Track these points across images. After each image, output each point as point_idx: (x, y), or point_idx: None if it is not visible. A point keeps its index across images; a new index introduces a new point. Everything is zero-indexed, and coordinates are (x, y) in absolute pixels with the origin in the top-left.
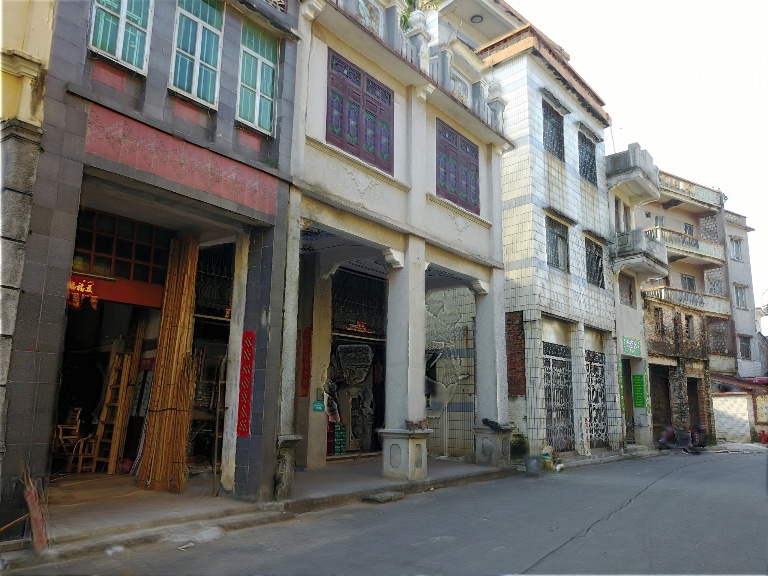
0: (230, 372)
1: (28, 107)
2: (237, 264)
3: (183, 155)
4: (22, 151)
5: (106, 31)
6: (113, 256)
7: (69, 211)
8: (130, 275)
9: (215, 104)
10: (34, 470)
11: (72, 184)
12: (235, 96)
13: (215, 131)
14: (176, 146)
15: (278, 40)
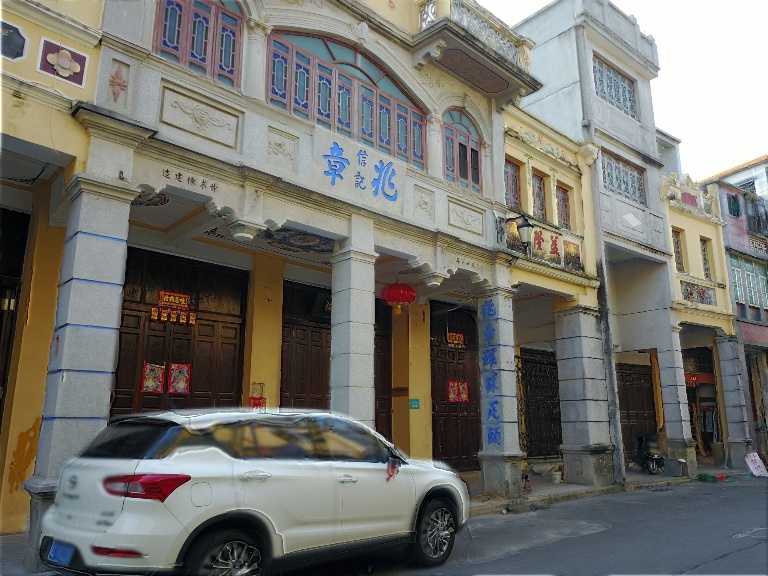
0: (767, 412)
1: (733, 330)
2: (760, 365)
3: (759, 331)
4: (735, 345)
5: (735, 292)
6: (698, 364)
7: (744, 361)
8: (703, 371)
9: (758, 305)
10: (755, 448)
11: (743, 352)
12: (762, 299)
13: (760, 316)
14: (757, 328)
15: (765, 266)
